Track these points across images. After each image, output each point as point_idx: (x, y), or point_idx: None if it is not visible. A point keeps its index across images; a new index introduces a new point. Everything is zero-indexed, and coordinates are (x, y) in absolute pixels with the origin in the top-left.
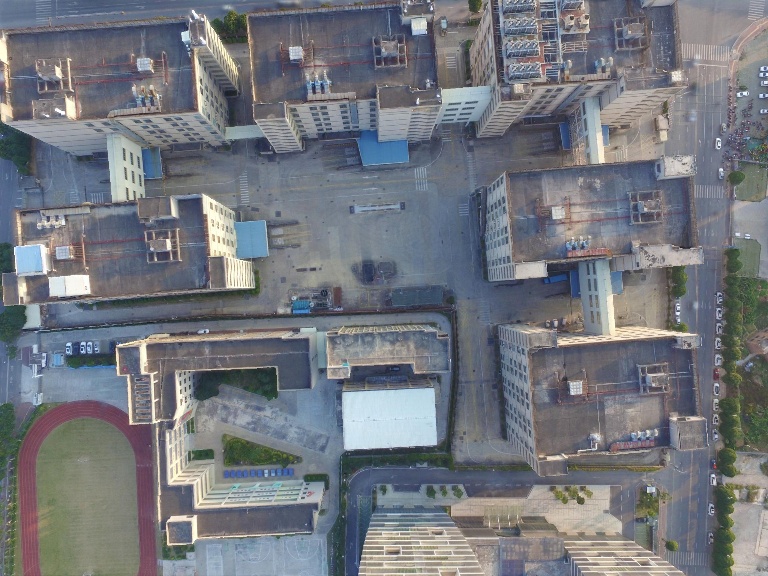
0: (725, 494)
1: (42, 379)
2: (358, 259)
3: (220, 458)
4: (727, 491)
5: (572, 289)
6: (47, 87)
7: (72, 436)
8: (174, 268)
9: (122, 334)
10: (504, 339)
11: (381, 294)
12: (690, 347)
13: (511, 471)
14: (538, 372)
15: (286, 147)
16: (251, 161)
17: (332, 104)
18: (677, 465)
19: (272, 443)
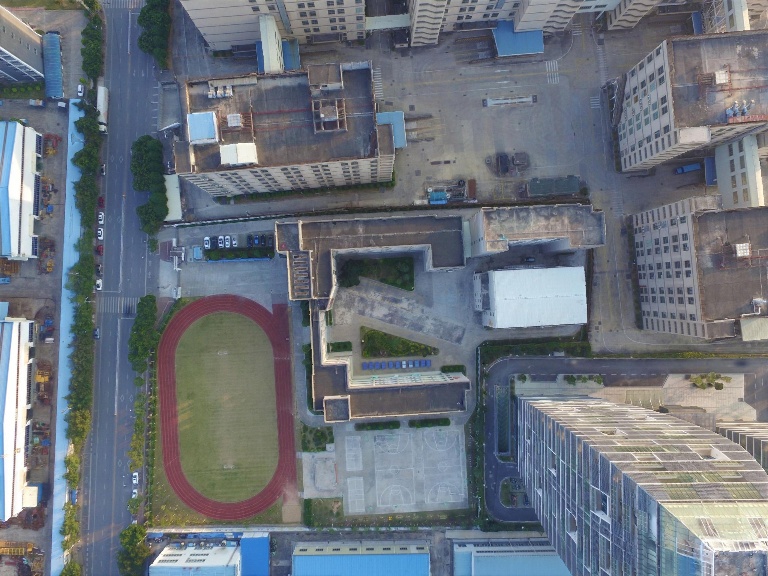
0: None
1: (180, 273)
2: (492, 152)
3: (358, 350)
4: None
5: (707, 177)
6: None
7: (210, 330)
8: (339, 138)
9: (259, 228)
10: (644, 224)
11: (515, 186)
12: None
13: (646, 360)
14: (701, 238)
15: (424, 37)
16: (384, 56)
17: None
18: None
19: (409, 335)
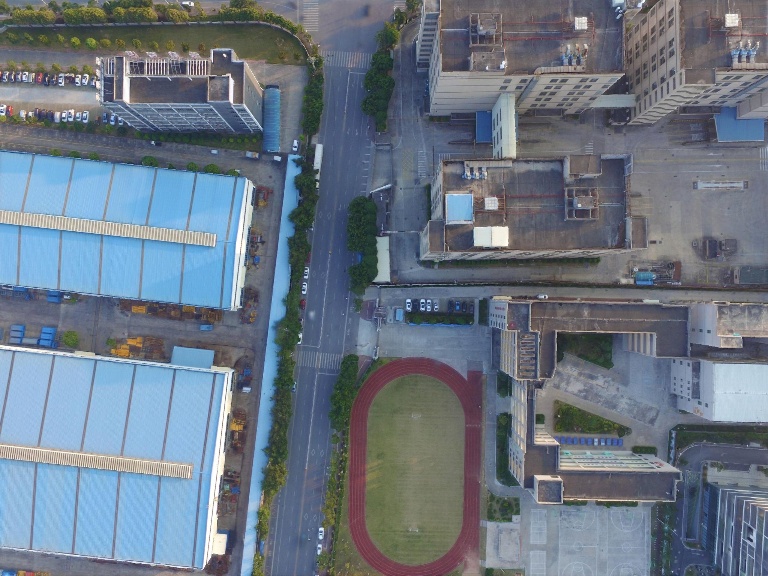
0: None
1: (379, 333)
2: (699, 235)
3: (550, 424)
4: None
5: None
6: (479, 41)
7: (405, 392)
8: (588, 226)
9: (460, 294)
10: None
11: (720, 271)
12: None
13: None
14: None
15: (647, 118)
16: (598, 131)
17: (752, 74)
18: None
19: (602, 412)
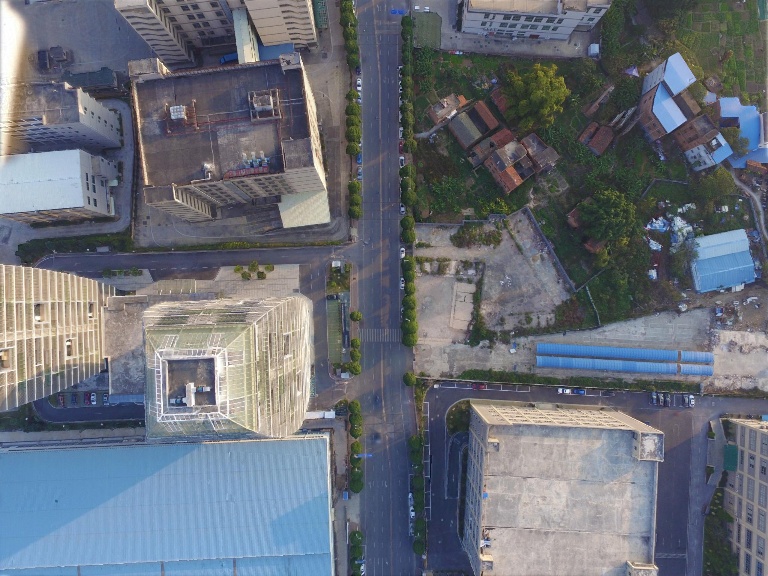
0: (403, 259)
1: None
2: (35, 49)
3: None
4: (406, 257)
5: None
6: None
7: None
8: None
9: None
10: None
11: None
12: (289, 64)
13: (197, 254)
14: (148, 105)
15: None
16: None
17: None
18: (366, 241)
19: None
